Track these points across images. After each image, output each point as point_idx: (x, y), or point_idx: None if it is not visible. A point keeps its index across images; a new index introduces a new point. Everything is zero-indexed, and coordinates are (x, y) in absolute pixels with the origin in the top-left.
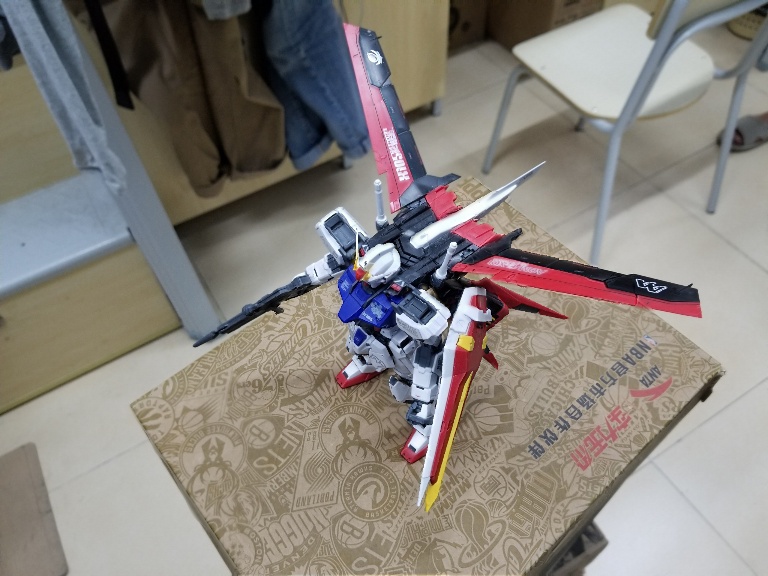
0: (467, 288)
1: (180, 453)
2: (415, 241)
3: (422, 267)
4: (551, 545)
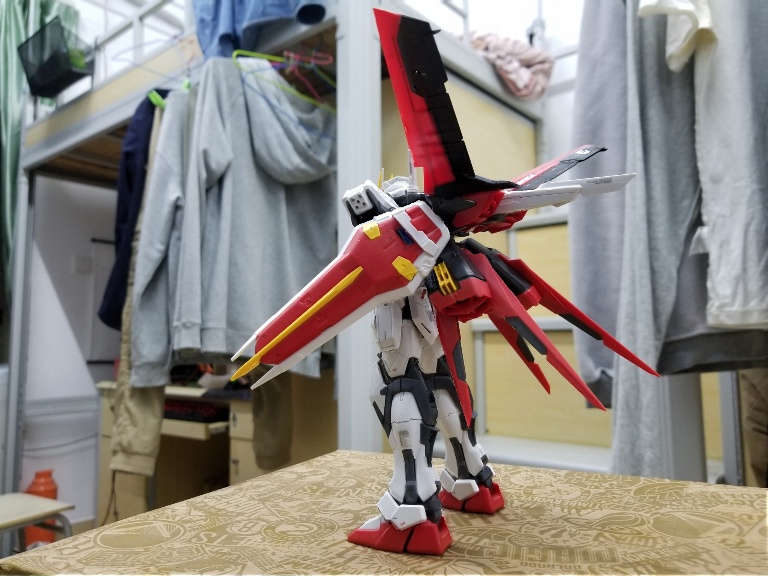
0: None
1: (304, 465)
2: None
3: None
4: None
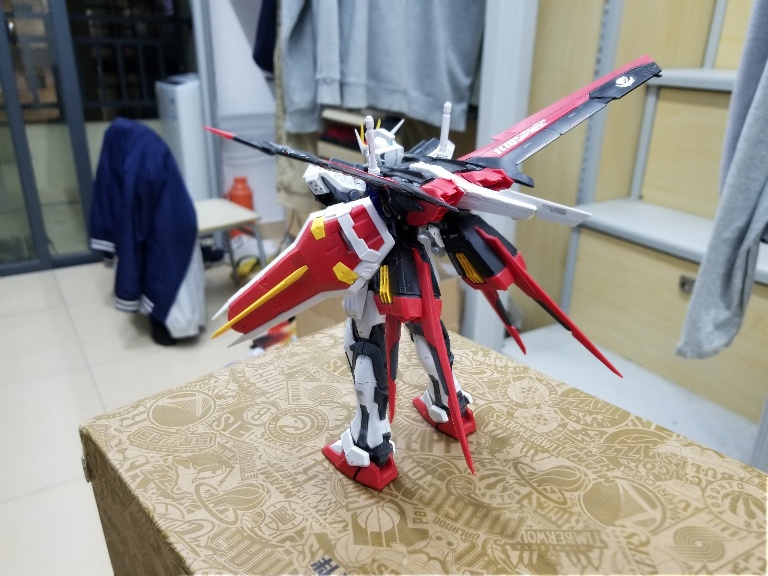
0: (368, 196)
1: None
2: (415, 163)
3: (383, 166)
4: (189, 567)
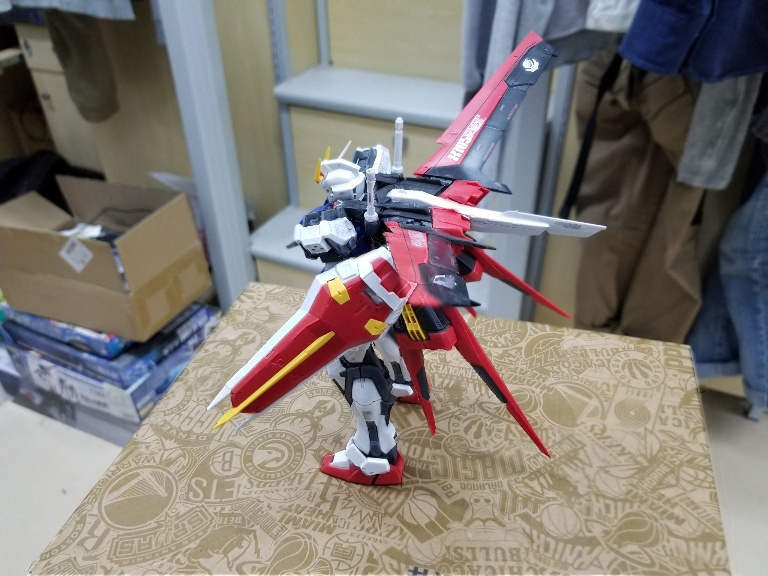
0: (383, 247)
1: (230, 324)
2: (392, 191)
3: None
4: None
